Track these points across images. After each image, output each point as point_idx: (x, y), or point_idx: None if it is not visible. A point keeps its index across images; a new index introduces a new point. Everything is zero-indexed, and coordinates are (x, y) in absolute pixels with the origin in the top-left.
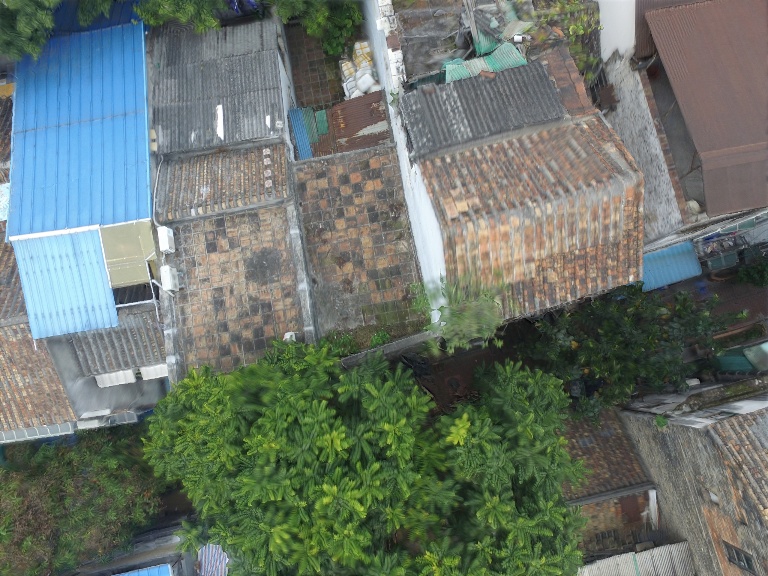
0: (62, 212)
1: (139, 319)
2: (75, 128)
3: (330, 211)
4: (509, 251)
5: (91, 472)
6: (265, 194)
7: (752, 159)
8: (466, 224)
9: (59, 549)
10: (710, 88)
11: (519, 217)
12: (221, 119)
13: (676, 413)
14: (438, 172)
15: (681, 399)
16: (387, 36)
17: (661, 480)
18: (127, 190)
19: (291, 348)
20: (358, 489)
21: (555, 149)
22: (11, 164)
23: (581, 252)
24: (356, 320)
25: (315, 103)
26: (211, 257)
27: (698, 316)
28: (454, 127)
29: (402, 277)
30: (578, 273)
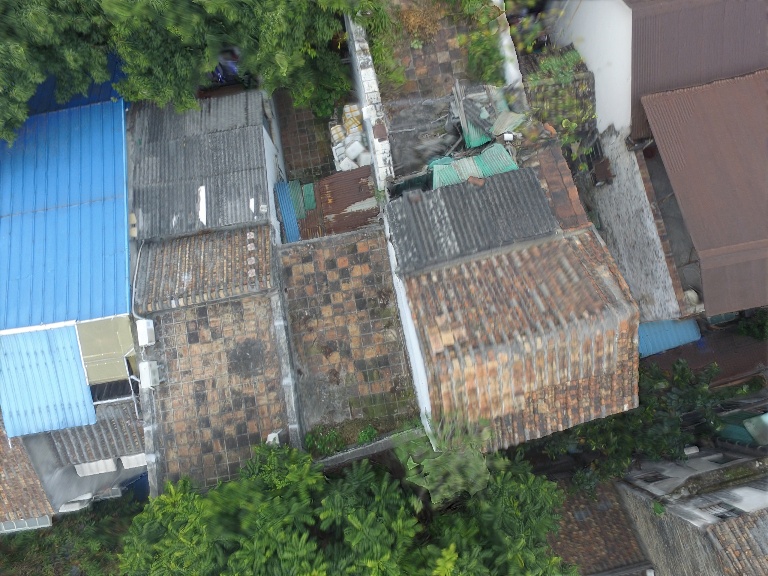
0: (37, 306)
1: (119, 410)
2: (52, 214)
3: (316, 297)
4: (497, 386)
5: (73, 553)
6: (248, 285)
7: (752, 257)
8: (451, 362)
9: None
10: (708, 180)
11: (507, 353)
12: (203, 202)
13: (674, 497)
14: (424, 292)
15: (680, 472)
16: (373, 125)
17: (659, 562)
18: (105, 282)
19: (273, 459)
20: None
21: (546, 269)
22: None
23: (573, 383)
24: (343, 413)
25: (304, 166)
26: (193, 348)
27: (697, 389)
28: (441, 240)
29: (390, 368)
30: (570, 403)
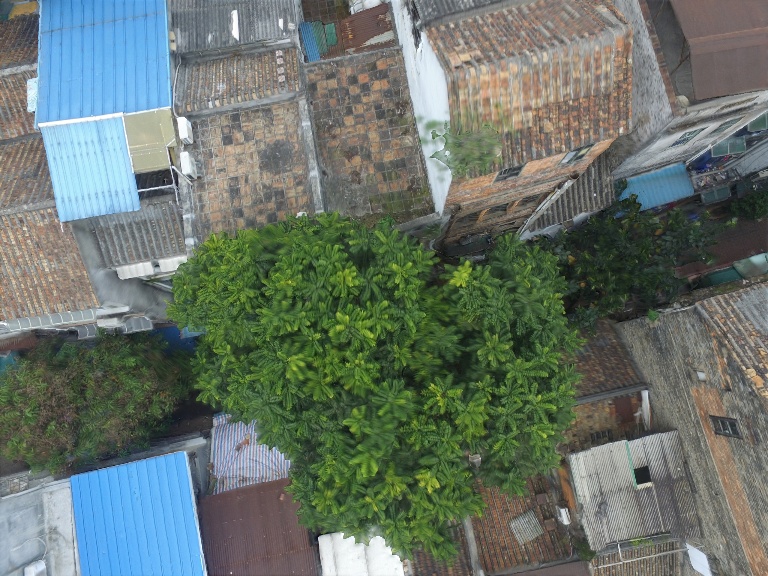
0: (87, 102)
1: (158, 210)
2: (99, 28)
3: (339, 109)
4: (508, 98)
5: (110, 371)
6: (278, 87)
7: (737, 45)
8: (469, 69)
9: (80, 441)
10: None
11: (517, 64)
12: (236, 23)
13: (667, 310)
14: (443, 36)
15: None
16: None
17: (653, 378)
18: (149, 82)
19: (304, 217)
20: (368, 319)
21: (551, 13)
22: (39, 60)
23: (575, 103)
24: (364, 208)
25: None
26: (227, 149)
27: (689, 227)
28: None
29: (407, 169)
30: (572, 124)
